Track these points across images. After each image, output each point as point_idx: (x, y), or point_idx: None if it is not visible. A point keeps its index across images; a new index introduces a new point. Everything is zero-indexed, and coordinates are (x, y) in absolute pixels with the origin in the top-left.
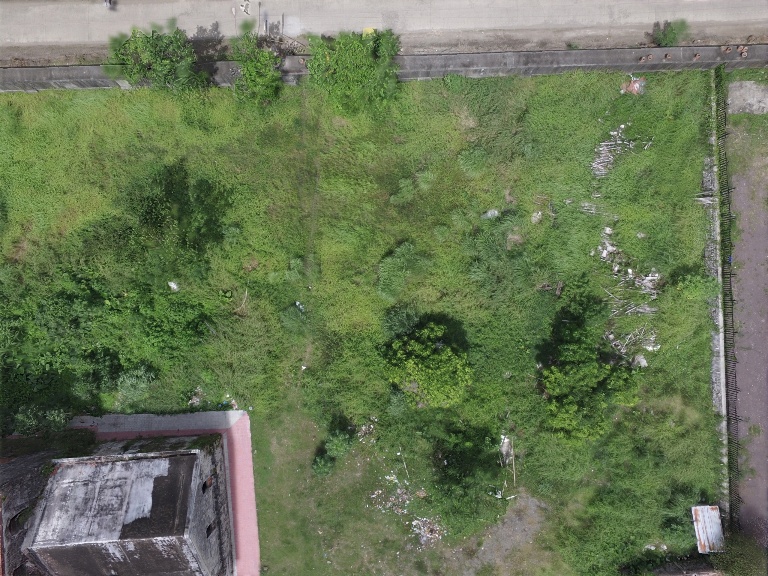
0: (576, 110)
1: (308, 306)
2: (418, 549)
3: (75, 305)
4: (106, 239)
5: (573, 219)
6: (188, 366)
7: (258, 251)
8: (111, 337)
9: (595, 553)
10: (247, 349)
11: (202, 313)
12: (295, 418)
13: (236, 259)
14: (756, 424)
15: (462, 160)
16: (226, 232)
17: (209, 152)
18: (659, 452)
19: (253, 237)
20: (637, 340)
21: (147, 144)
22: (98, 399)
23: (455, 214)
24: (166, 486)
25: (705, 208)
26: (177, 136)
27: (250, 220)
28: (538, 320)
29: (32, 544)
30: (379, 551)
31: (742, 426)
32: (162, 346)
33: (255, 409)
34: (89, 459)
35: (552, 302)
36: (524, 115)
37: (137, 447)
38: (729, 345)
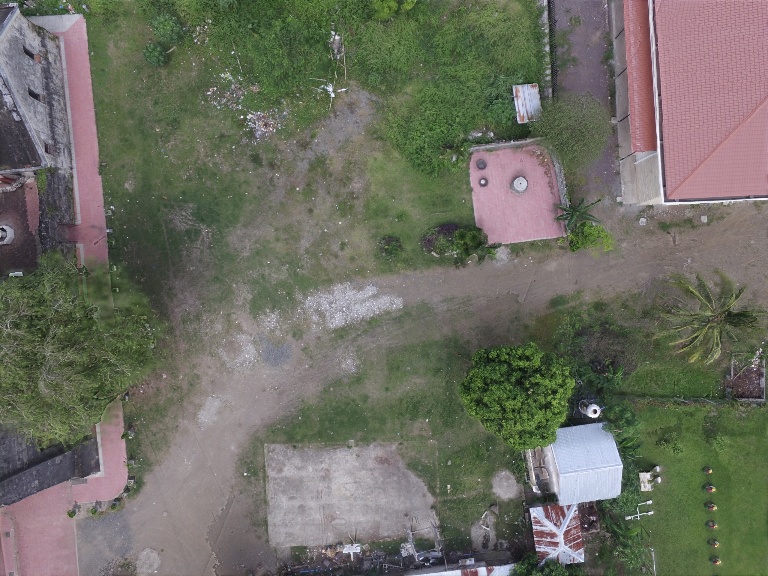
0: None
1: None
2: (253, 142)
3: None
4: None
5: None
6: None
7: None
8: None
9: (420, 132)
10: None
11: None
12: (131, 22)
13: None
14: (577, 14)
15: None
16: None
17: None
18: (481, 36)
19: None
20: None
21: None
22: None
23: None
24: None
25: None
26: None
27: None
28: None
29: None
30: (215, 145)
31: (563, 16)
32: None
33: (90, 10)
34: None
35: None
36: None
37: None
38: None
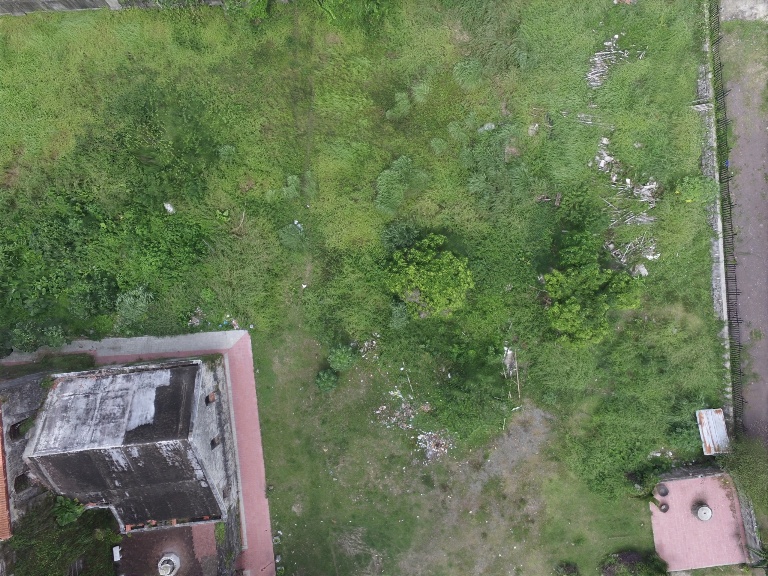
0: (570, 20)
1: (307, 225)
2: (424, 463)
3: (70, 224)
4: (100, 162)
5: (570, 129)
6: (187, 286)
7: (255, 170)
8: (108, 260)
9: (601, 459)
10: (246, 267)
11: (200, 234)
12: (297, 336)
13: (232, 179)
14: (757, 328)
15: (458, 71)
16: (222, 150)
17: (202, 73)
18: (662, 357)
19: (249, 156)
20: (637, 249)
21: (139, 66)
22: (96, 322)
23: (452, 126)
24: (168, 395)
25: (701, 116)
26: (169, 57)
27: (246, 139)
28: (538, 231)
29: (33, 453)
30: (385, 466)
31: (743, 330)
32: (160, 266)
33: (256, 328)
34: (89, 373)
35: (551, 213)
36: (518, 26)
37: None
38: (728, 249)
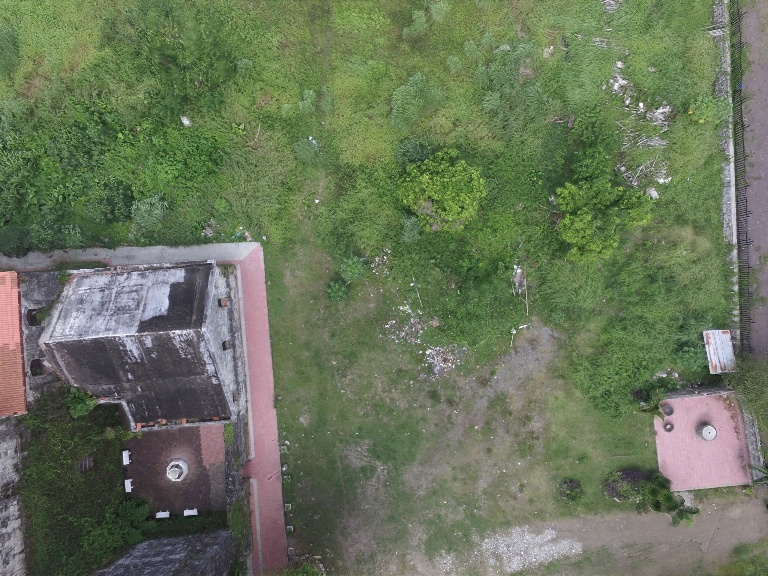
0: None
1: (321, 141)
2: (431, 378)
3: (89, 129)
4: (118, 75)
5: (585, 52)
6: (201, 196)
7: (271, 86)
8: (124, 170)
9: (607, 377)
10: (260, 179)
11: (215, 147)
12: (308, 250)
13: (249, 93)
14: (766, 253)
15: None
16: (239, 62)
17: None
18: (671, 278)
19: (266, 71)
20: (648, 172)
21: None
22: (111, 230)
23: (468, 45)
24: (182, 290)
25: (715, 42)
26: None
27: (263, 54)
28: (550, 152)
29: (49, 338)
30: (393, 380)
31: (752, 255)
32: (175, 175)
33: (269, 239)
34: (105, 269)
35: (564, 134)
36: None
37: None
38: (740, 172)
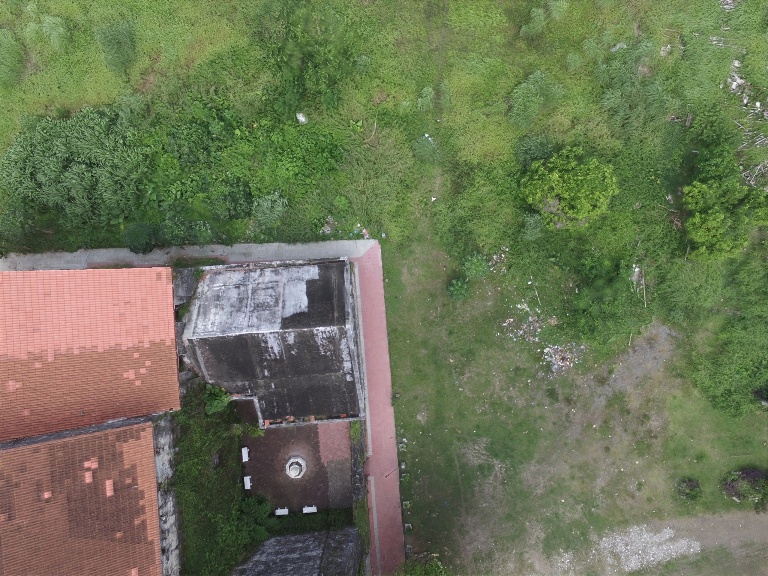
0: None
1: (437, 139)
2: (549, 377)
3: (213, 125)
4: (234, 71)
5: (703, 50)
6: (321, 193)
7: (387, 83)
8: (241, 167)
9: (729, 376)
10: (380, 176)
11: (332, 144)
12: (426, 248)
13: (366, 90)
14: None
15: None
16: (359, 59)
17: None
18: None
19: (383, 68)
20: (766, 172)
21: None
22: (230, 227)
23: (587, 43)
24: (319, 287)
25: None
26: None
27: (380, 51)
28: (668, 151)
29: (193, 335)
30: (511, 378)
31: None
32: (295, 172)
33: (387, 237)
34: (237, 266)
35: (682, 133)
36: None
37: None
38: None
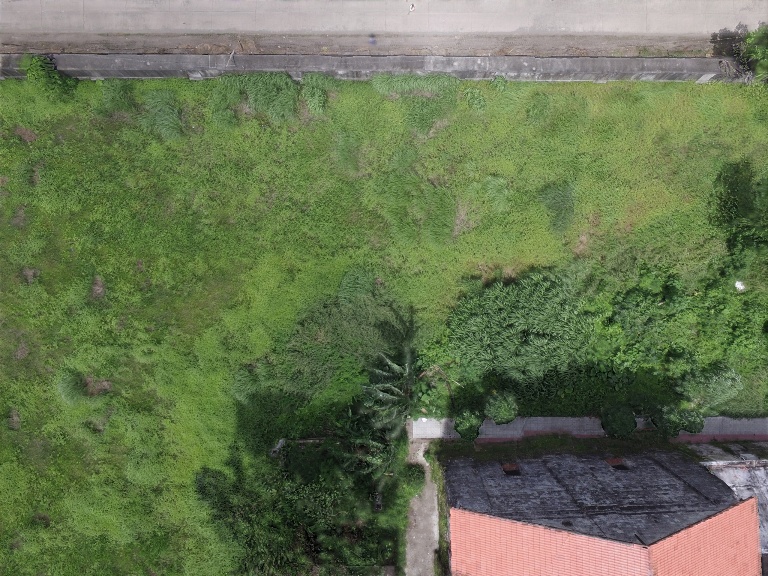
0: None
1: None
2: None
3: (682, 303)
4: (673, 236)
5: None
6: None
7: None
8: (685, 337)
9: None
10: None
11: None
12: None
13: None
14: None
15: None
16: None
17: None
18: None
19: None
20: None
21: (711, 140)
22: (677, 400)
23: None
24: None
25: None
26: (746, 133)
27: None
28: None
29: None
30: None
31: None
32: None
33: None
34: (740, 463)
35: None
36: None
37: (741, 451)
38: None
